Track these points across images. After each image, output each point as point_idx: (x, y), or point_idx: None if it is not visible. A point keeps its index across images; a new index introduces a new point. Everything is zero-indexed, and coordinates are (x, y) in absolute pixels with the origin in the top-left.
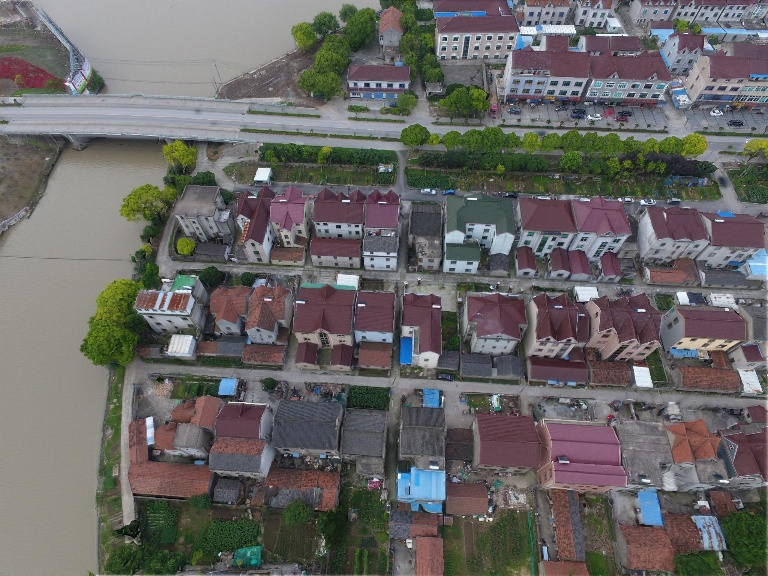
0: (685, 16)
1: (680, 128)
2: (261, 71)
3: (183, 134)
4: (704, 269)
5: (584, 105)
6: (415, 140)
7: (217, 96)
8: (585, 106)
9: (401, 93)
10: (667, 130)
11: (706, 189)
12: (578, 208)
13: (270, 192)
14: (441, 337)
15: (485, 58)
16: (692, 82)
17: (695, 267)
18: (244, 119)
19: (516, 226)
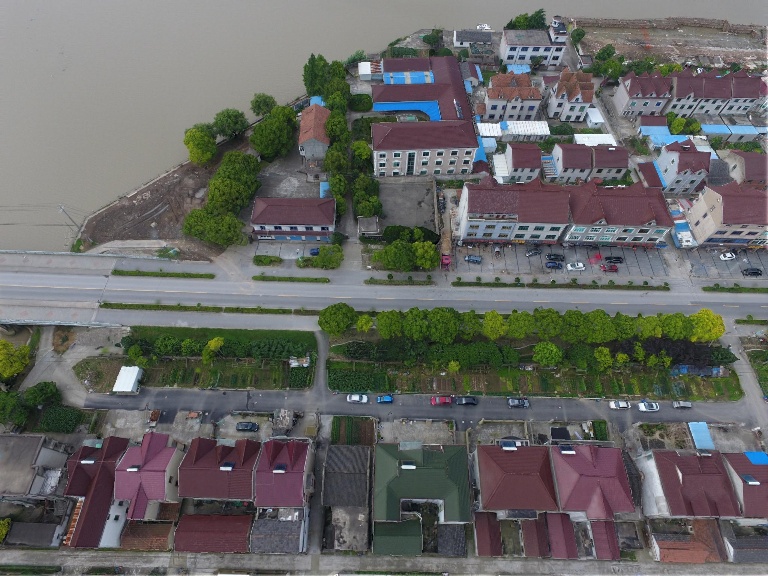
0: (681, 109)
1: (684, 281)
2: (144, 193)
3: (16, 316)
4: (731, 537)
5: (562, 247)
6: (337, 330)
7: (80, 236)
8: (563, 248)
9: (325, 236)
10: (668, 285)
11: (722, 381)
12: (559, 466)
13: (120, 442)
14: None
15: (436, 173)
16: (697, 218)
17: (718, 532)
18: (107, 285)
19: (473, 490)
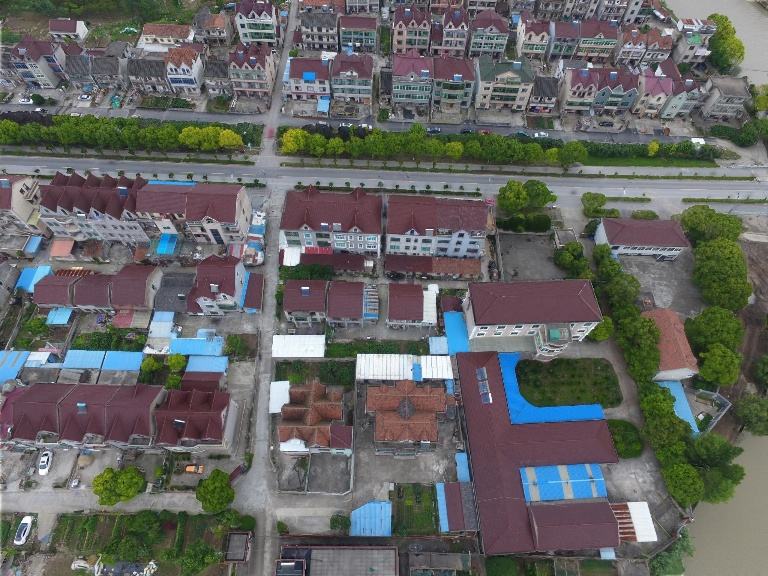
0: None
1: (277, 194)
2: None
3: None
4: None
5: None
6: None
7: None
8: None
9: None
10: None
11: None
12: None
13: None
14: (522, 19)
15: None
16: None
17: None
18: (763, 193)
19: (475, 73)
